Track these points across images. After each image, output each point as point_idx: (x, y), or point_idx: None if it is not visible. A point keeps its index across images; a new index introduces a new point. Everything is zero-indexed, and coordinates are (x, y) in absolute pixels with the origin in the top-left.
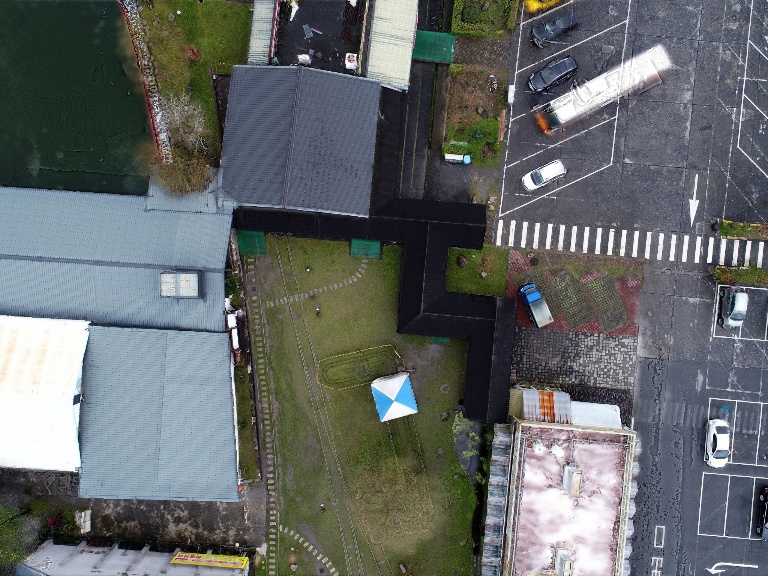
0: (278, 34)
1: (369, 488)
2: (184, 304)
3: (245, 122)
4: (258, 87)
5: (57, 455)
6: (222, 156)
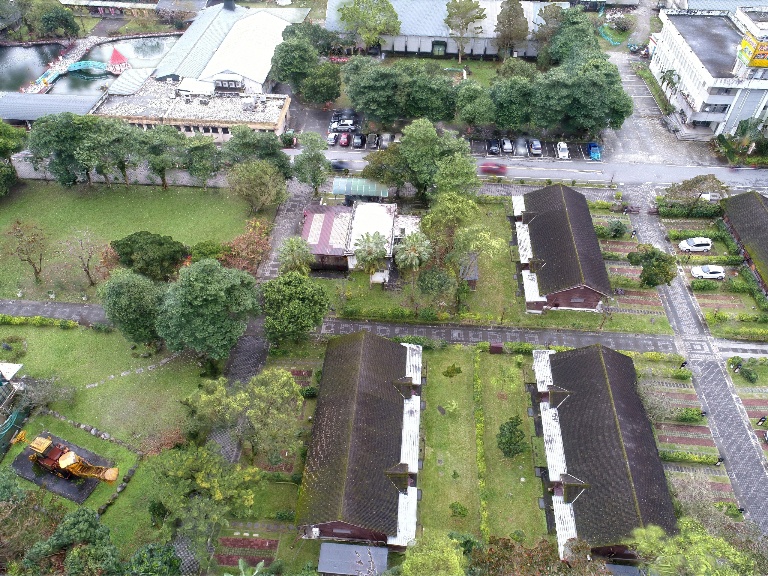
0: (149, 1)
1: (316, 6)
2: (237, 11)
3: (176, 5)
4: (165, 3)
5: (284, 24)
6: (186, 11)
